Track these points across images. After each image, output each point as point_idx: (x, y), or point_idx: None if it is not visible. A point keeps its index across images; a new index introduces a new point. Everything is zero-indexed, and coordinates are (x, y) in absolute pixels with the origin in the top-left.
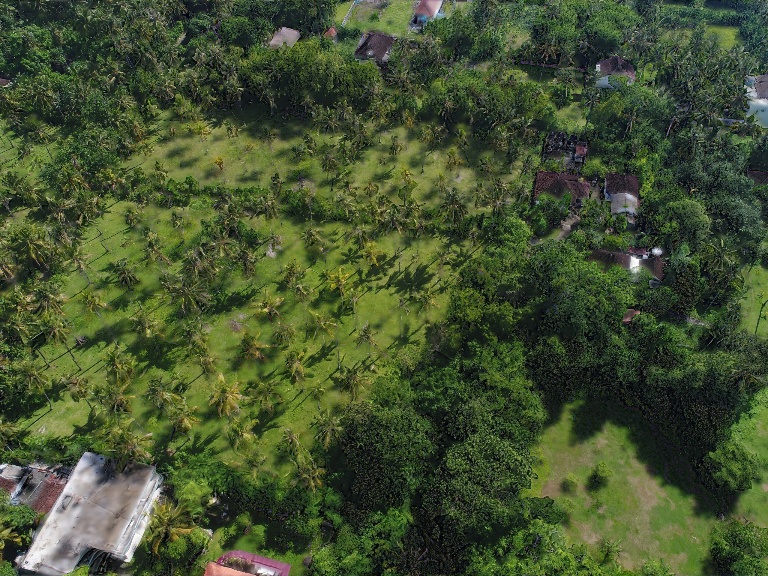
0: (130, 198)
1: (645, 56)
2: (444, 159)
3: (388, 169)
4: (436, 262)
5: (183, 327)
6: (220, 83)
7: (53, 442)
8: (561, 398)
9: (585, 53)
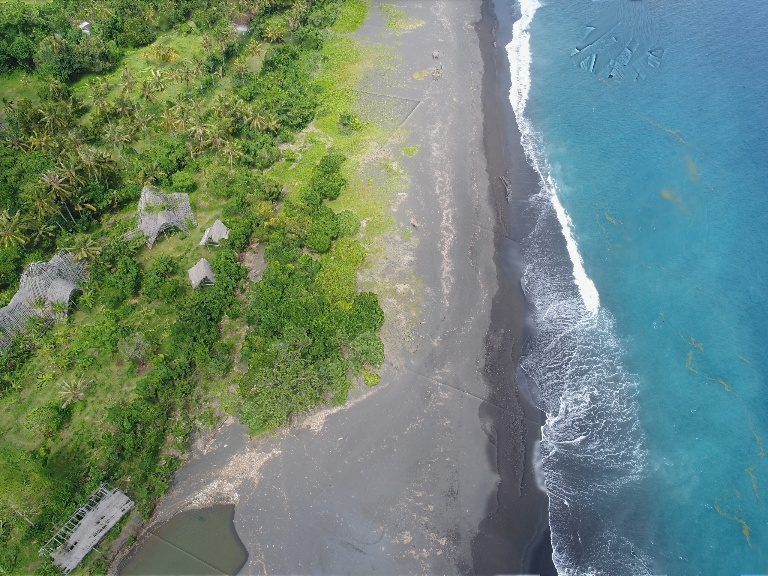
0: None
1: None
2: None
3: None
4: None
5: None
6: None
7: None
8: (5, 78)
9: None
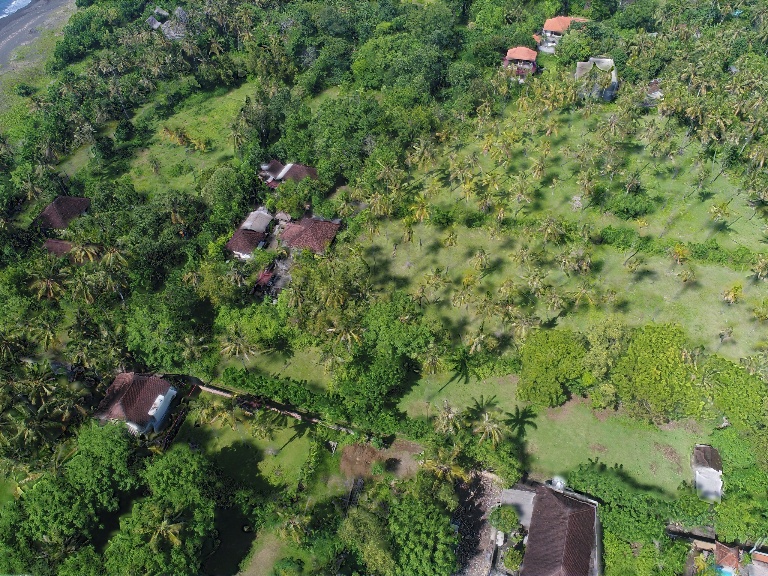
0: None
1: None
2: None
3: (487, 278)
4: None
5: None
6: None
7: (646, 107)
8: None
9: None
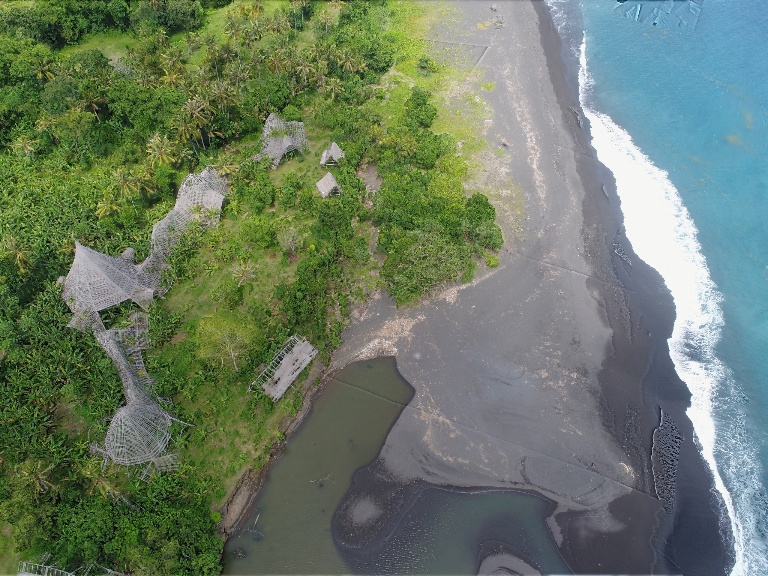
0: None
1: None
2: None
3: None
4: None
5: None
6: None
7: None
8: (101, 37)
9: None
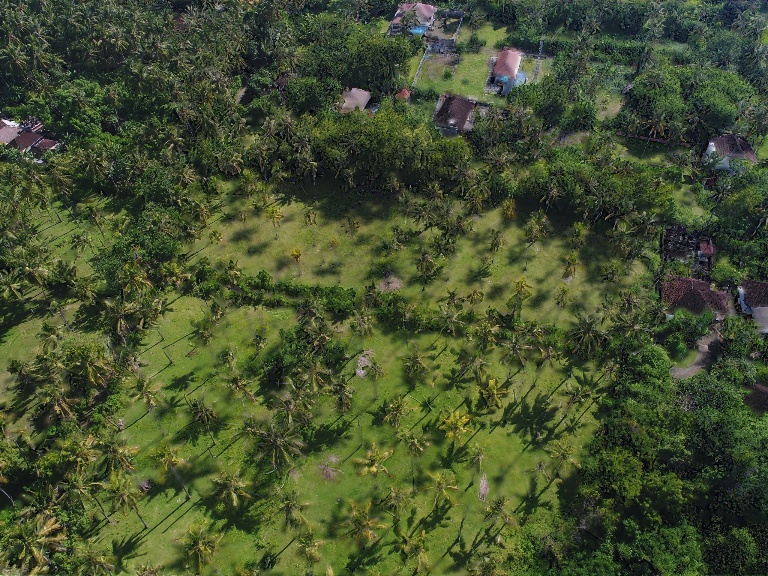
0: (194, 293)
1: (762, 133)
2: (547, 253)
3: None
4: (557, 392)
5: (265, 471)
6: (289, 154)
7: None
8: None
9: (693, 127)
